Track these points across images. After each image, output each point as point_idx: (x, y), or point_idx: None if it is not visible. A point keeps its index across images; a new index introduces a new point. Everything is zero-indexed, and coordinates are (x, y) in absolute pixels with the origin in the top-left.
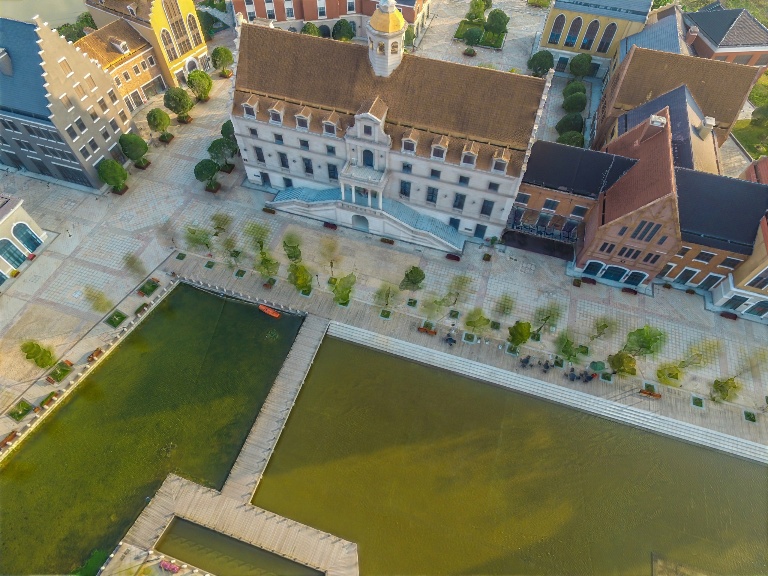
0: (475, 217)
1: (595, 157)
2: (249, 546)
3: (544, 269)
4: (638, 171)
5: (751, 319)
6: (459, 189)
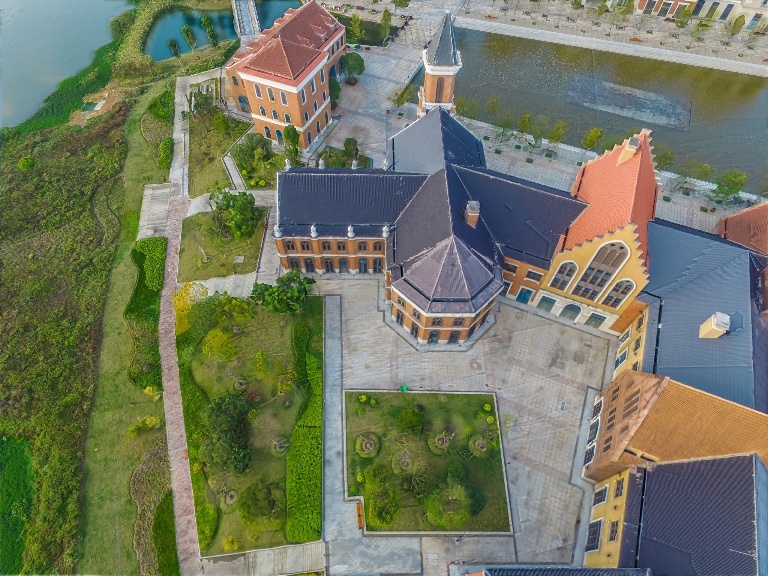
0: None
1: None
2: None
3: None
4: None
5: None
6: None
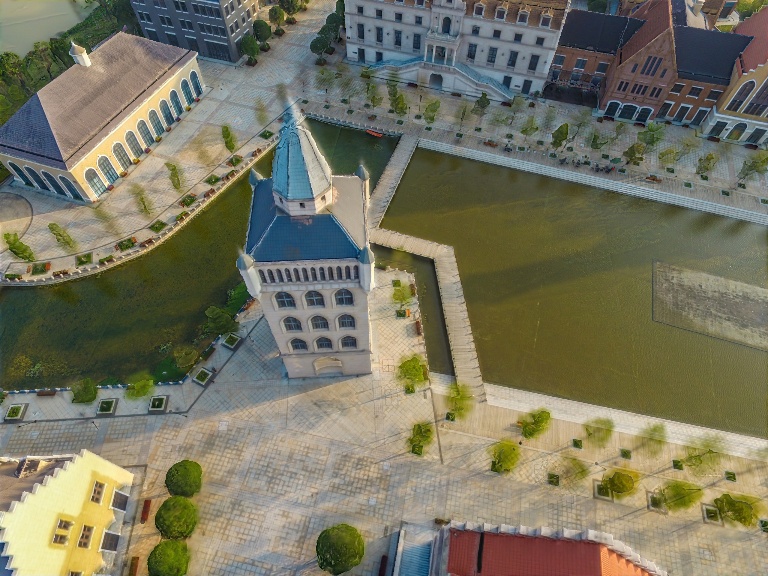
0: (524, 73)
1: (615, 20)
2: (381, 246)
3: (575, 112)
4: (646, 26)
5: (730, 142)
6: (513, 47)
